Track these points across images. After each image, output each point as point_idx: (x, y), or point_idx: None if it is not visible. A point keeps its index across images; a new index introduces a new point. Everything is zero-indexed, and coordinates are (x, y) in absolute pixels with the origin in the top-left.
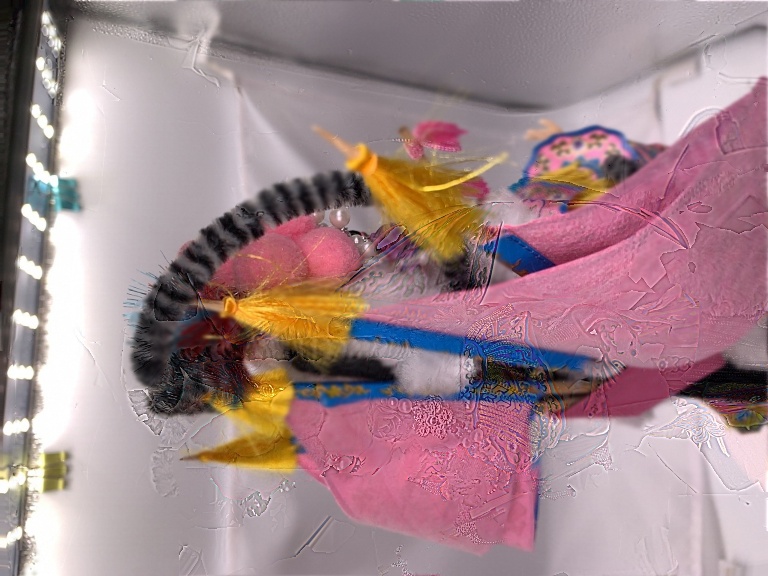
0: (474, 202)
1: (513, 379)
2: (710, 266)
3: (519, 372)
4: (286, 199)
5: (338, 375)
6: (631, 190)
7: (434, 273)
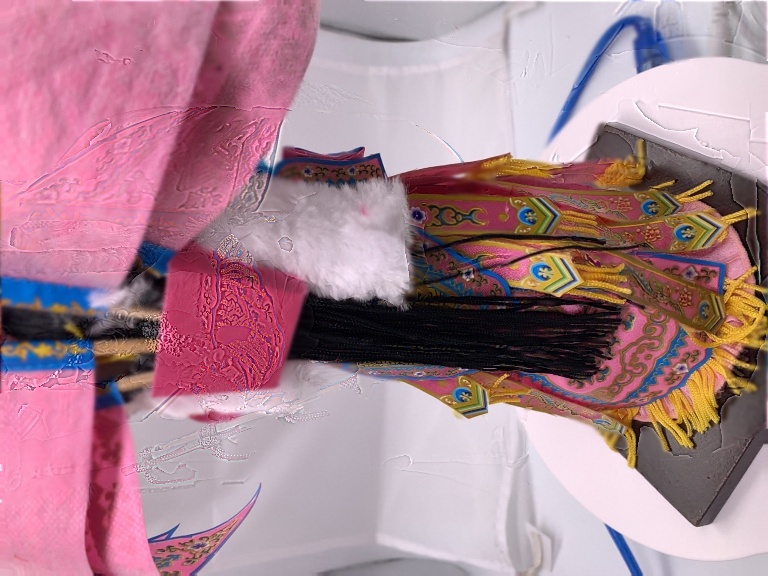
0: (189, 104)
1: (245, 305)
2: (305, 244)
3: (248, 299)
4: (147, 48)
5: (16, 292)
6: (557, 71)
7: (174, 178)
